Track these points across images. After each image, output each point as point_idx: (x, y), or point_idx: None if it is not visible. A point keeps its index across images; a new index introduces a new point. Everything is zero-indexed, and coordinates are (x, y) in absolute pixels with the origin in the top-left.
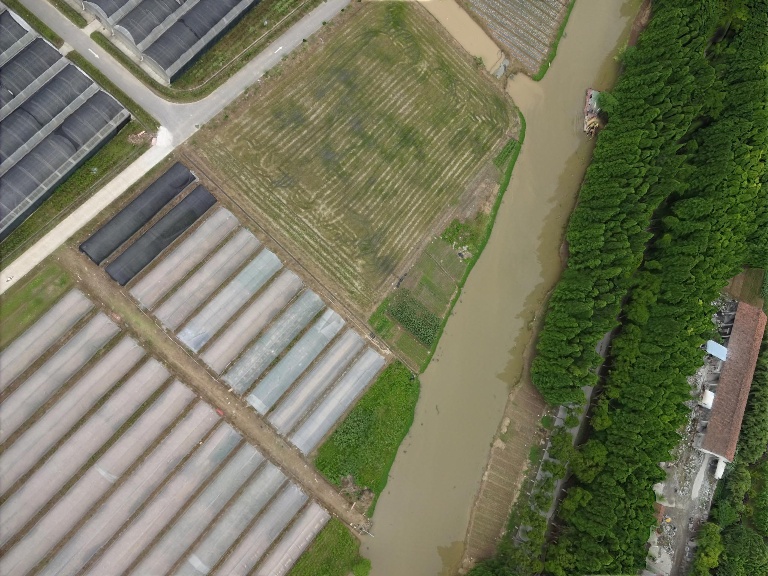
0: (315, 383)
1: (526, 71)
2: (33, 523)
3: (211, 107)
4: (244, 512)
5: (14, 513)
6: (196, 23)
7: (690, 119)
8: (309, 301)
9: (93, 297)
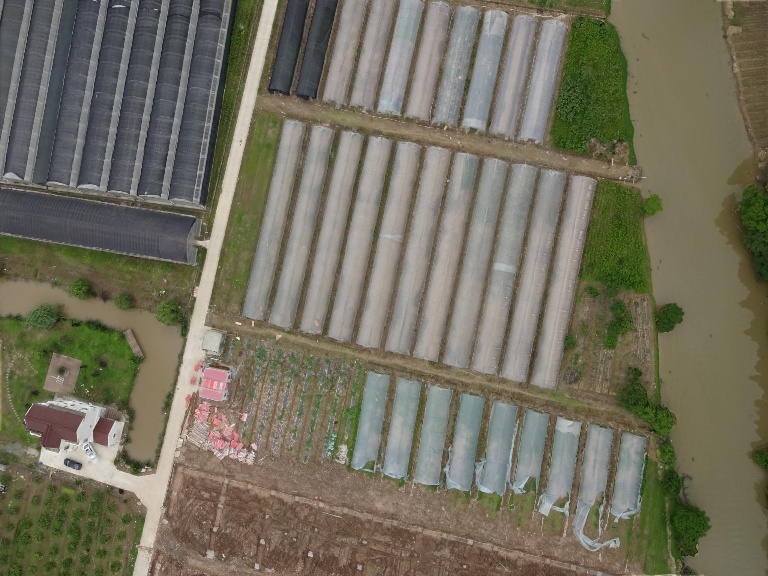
0: (513, 82)
1: None
2: (364, 297)
3: None
4: (517, 214)
5: (348, 297)
6: None
7: None
8: (464, 18)
9: (301, 121)
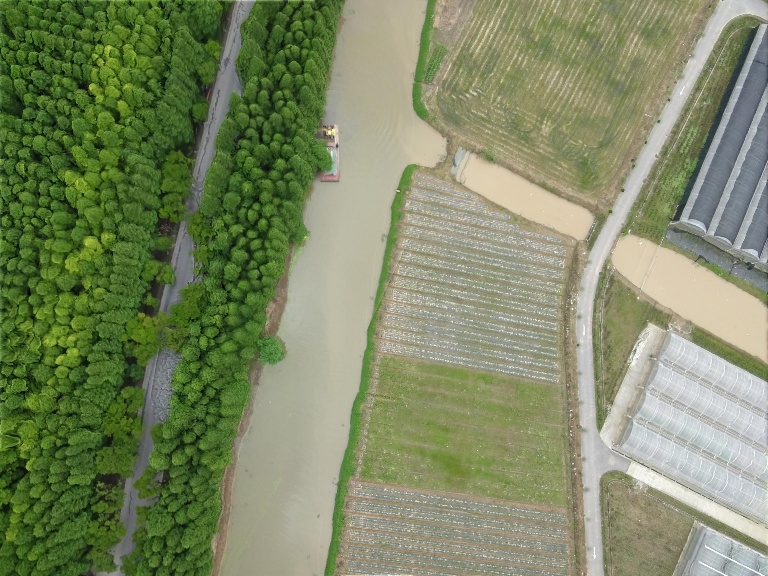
0: None
1: (428, 169)
2: None
3: (718, 19)
4: None
5: None
6: (761, 72)
7: (242, 104)
8: None
9: None
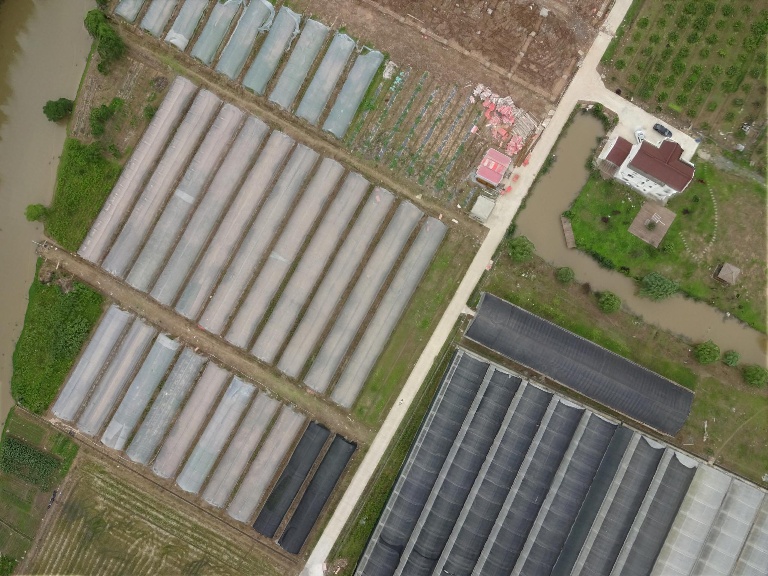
0: (120, 373)
1: None
2: (324, 210)
3: None
4: (158, 244)
5: (340, 215)
6: None
7: None
8: (143, 452)
9: (334, 404)
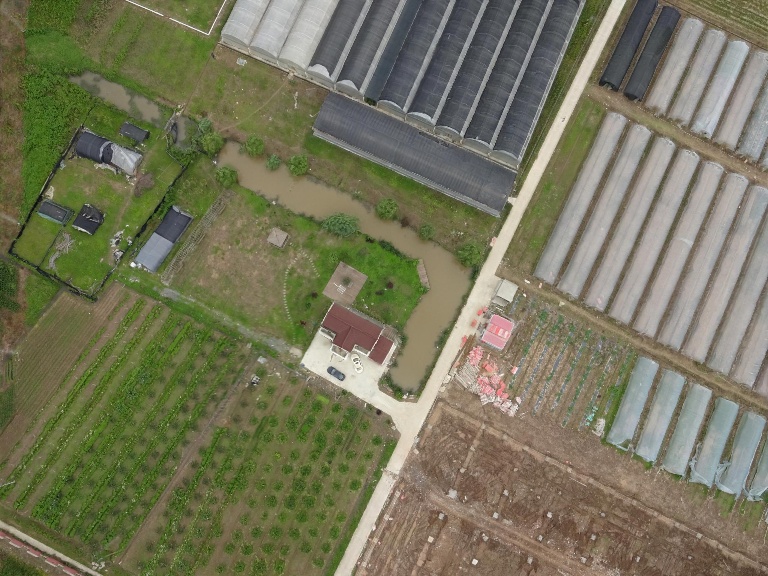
0: None
1: None
2: (648, 289)
3: None
4: None
5: (633, 284)
6: None
7: None
8: None
9: None
